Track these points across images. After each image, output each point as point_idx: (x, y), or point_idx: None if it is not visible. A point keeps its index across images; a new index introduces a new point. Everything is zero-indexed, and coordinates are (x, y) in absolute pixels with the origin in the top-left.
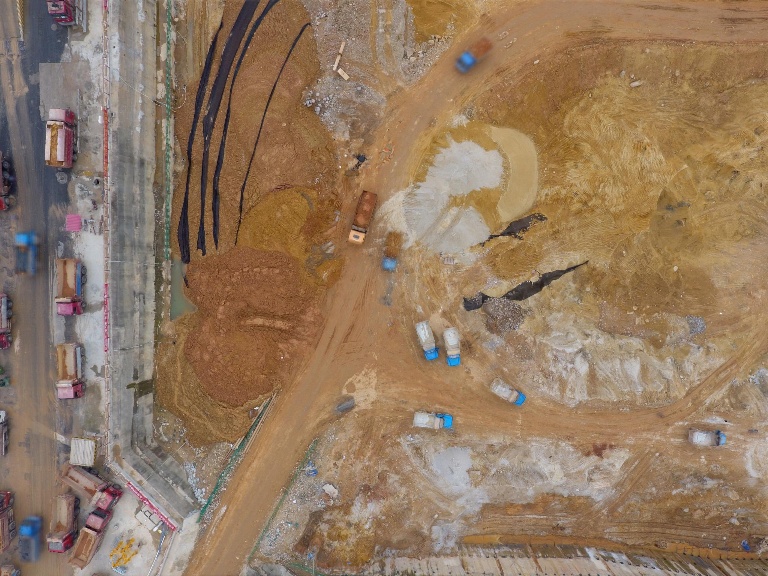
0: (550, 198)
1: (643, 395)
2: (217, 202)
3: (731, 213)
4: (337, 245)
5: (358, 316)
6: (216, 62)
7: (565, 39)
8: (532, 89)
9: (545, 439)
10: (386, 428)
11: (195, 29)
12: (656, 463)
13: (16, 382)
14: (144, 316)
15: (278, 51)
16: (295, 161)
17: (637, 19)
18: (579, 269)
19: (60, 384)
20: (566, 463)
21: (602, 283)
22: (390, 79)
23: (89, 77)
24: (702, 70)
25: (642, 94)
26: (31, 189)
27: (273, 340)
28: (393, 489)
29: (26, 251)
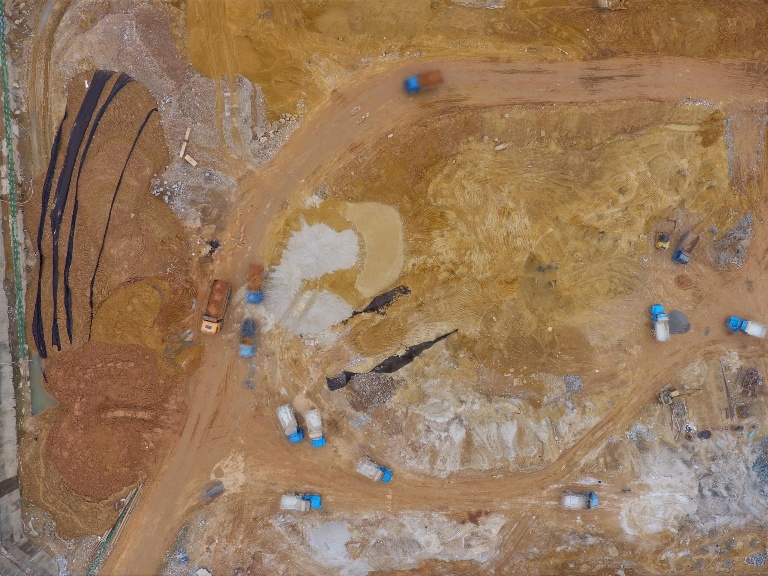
0: (417, 268)
1: (516, 461)
2: (69, 297)
3: (601, 273)
4: (196, 332)
5: (222, 401)
6: (62, 153)
7: (419, 110)
8: (388, 163)
9: (418, 511)
10: (257, 510)
11: (38, 120)
12: (534, 526)
13: None
14: (1, 416)
15: (123, 140)
16: (143, 253)
17: (494, 85)
18: (450, 337)
19: None
20: (442, 532)
21: (476, 348)
22: (239, 163)
23: None
24: (568, 129)
25: (508, 156)
26: None
27: (136, 431)
28: (271, 567)
29: None
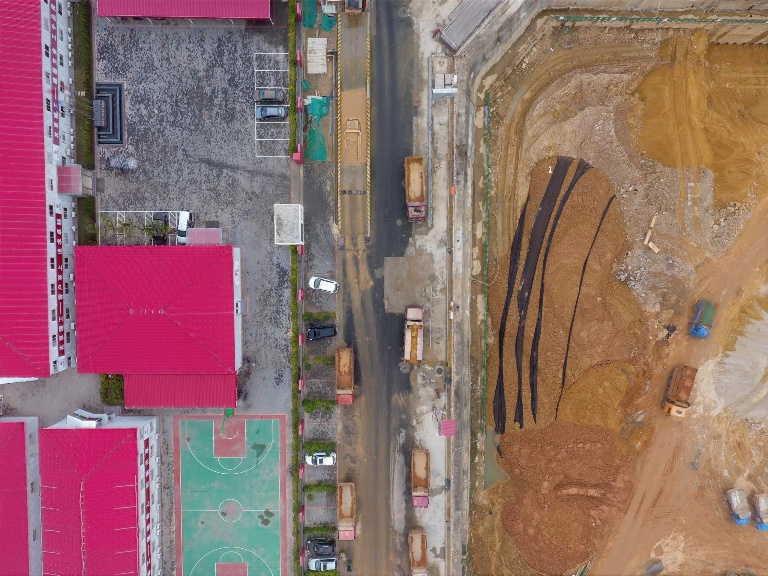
0: None
1: None
2: (535, 376)
3: None
4: (647, 413)
5: (666, 481)
6: (525, 236)
7: None
8: None
9: None
10: None
11: (505, 204)
12: None
13: (357, 565)
14: None
15: (588, 225)
16: (615, 337)
17: None
18: None
19: (416, 574)
20: None
21: None
22: (698, 250)
23: (432, 270)
24: None
25: None
26: (375, 379)
27: (586, 508)
28: None
29: (369, 438)
